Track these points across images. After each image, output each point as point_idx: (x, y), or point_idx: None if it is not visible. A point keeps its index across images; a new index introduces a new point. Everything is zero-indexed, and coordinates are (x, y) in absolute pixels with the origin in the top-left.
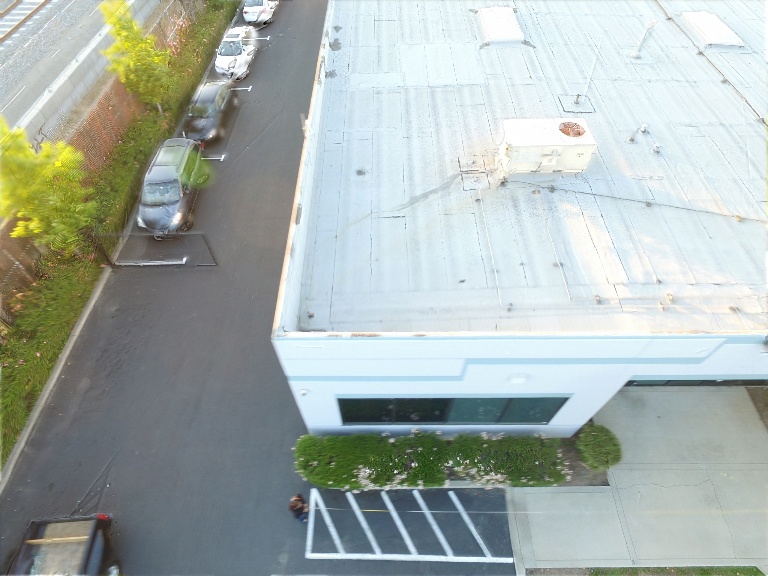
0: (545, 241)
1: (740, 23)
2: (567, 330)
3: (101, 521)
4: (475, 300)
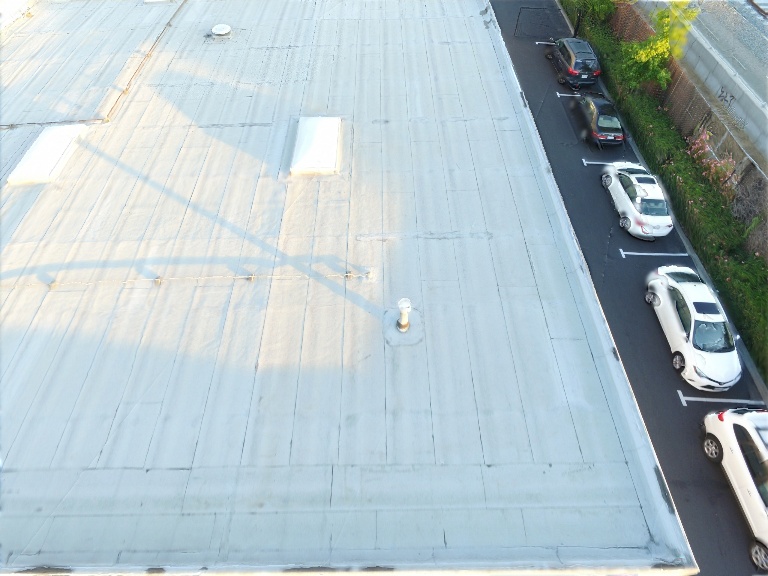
0: None
1: (126, 3)
2: None
3: None
4: None
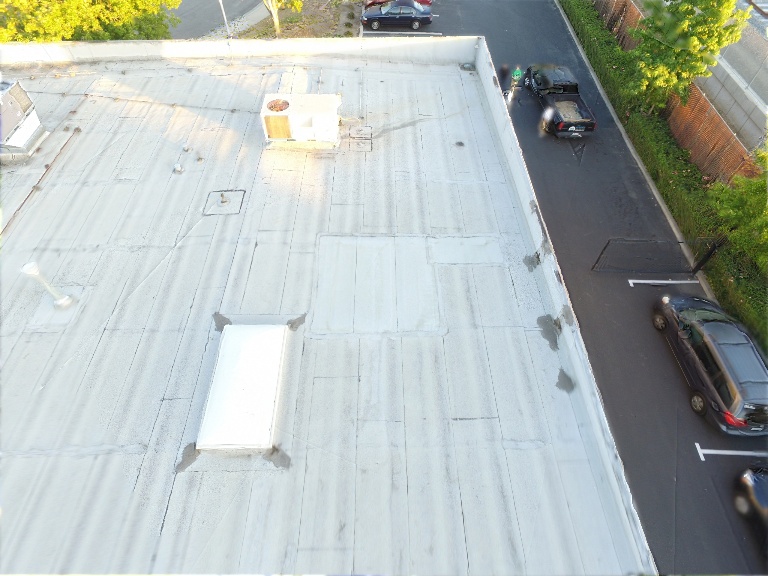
0: (323, 93)
1: None
2: (329, 60)
3: (560, 123)
4: (376, 74)
